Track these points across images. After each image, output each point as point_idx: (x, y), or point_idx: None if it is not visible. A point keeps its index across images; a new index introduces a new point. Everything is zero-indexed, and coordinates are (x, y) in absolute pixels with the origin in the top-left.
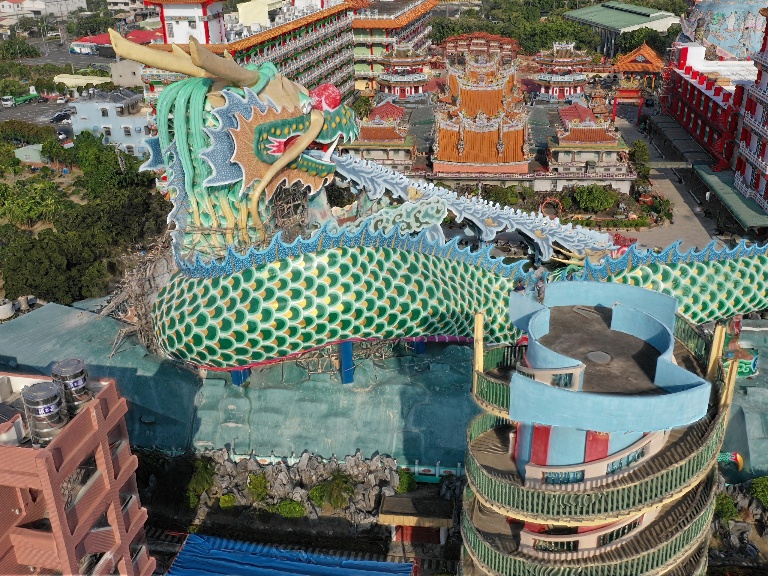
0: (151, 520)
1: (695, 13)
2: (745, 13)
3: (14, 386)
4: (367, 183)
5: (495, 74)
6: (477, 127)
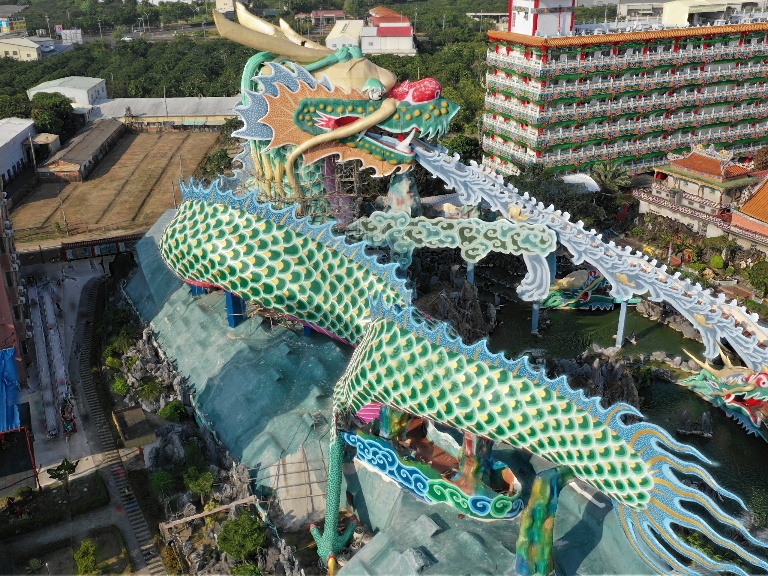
0: (94, 354)
1: None
2: None
3: None
4: (459, 186)
5: None
6: None
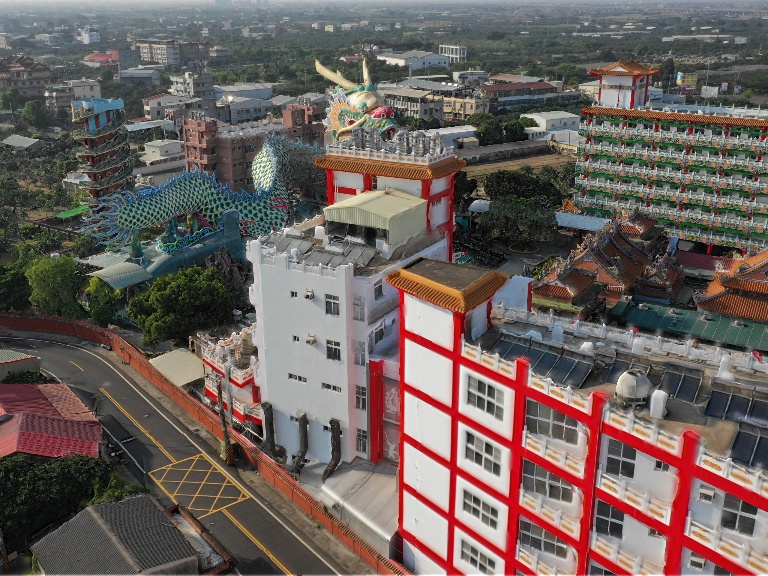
0: None
1: None
2: None
3: (256, 138)
4: None
5: None
6: None
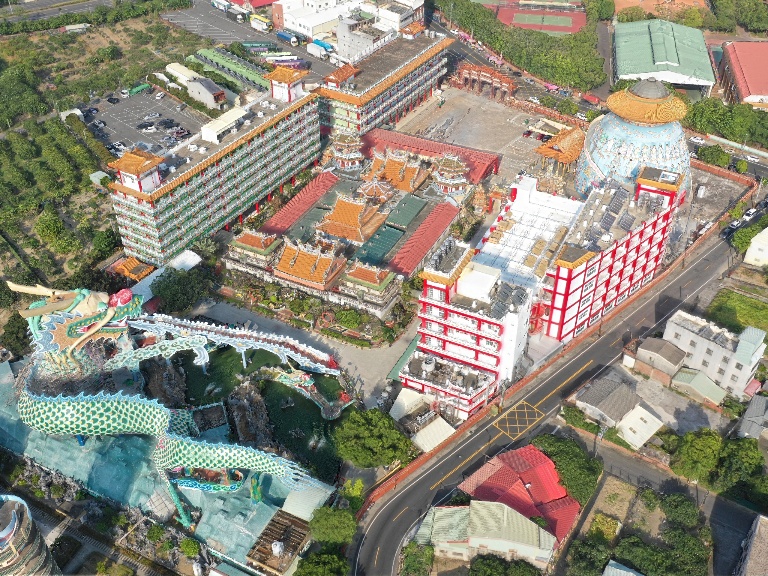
0: None
1: (598, 124)
2: (621, 141)
3: None
4: (153, 330)
5: (404, 165)
6: (307, 251)
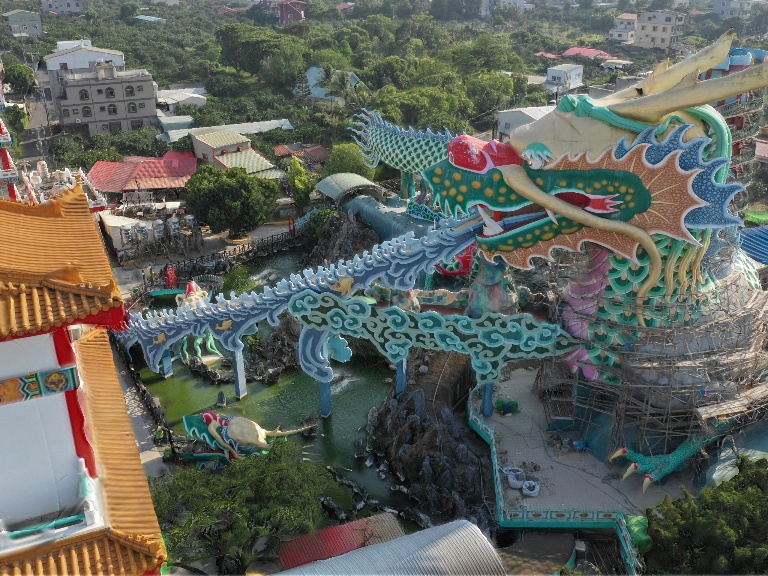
0: None
1: None
2: None
3: None
4: None
5: None
6: None
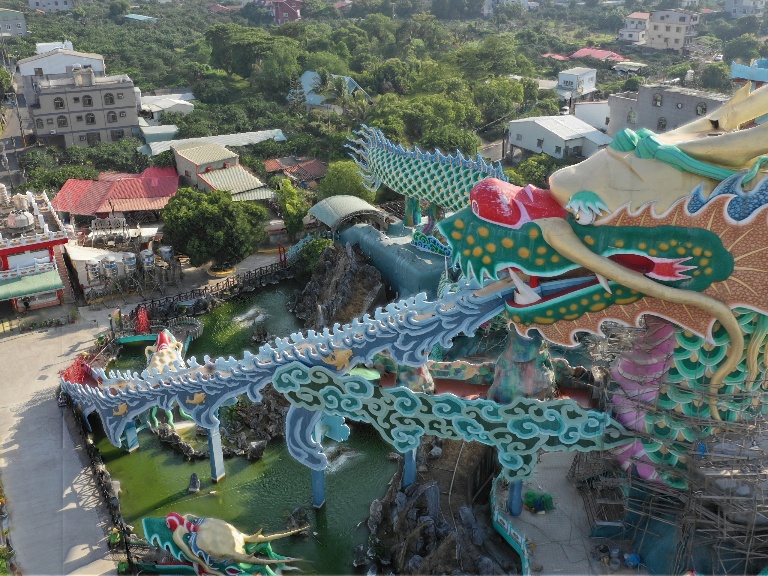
0: None
1: None
2: None
3: None
4: None
5: None
6: None
